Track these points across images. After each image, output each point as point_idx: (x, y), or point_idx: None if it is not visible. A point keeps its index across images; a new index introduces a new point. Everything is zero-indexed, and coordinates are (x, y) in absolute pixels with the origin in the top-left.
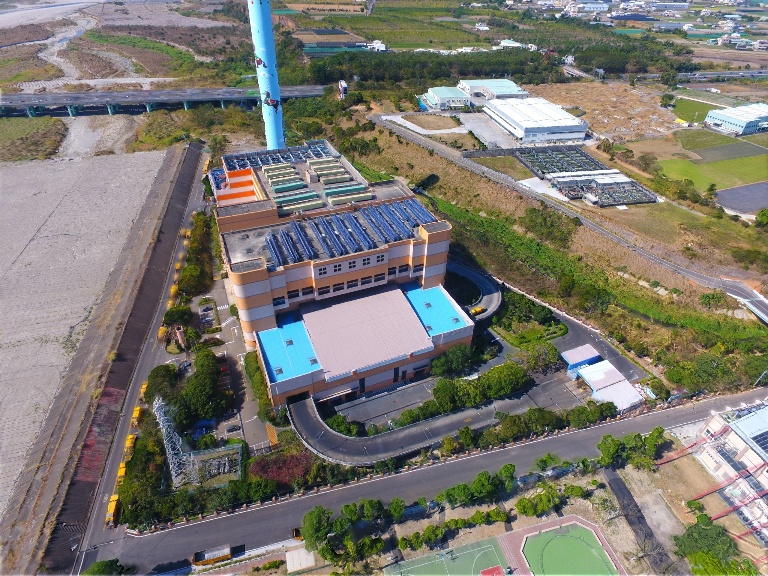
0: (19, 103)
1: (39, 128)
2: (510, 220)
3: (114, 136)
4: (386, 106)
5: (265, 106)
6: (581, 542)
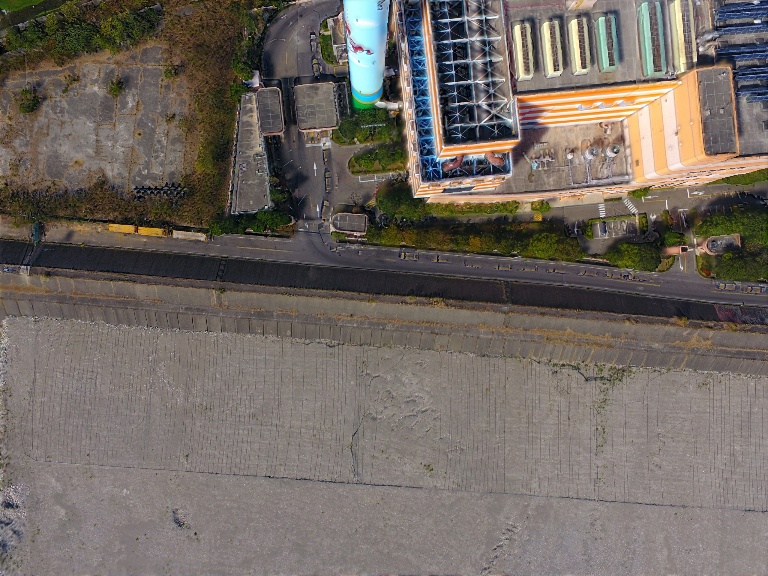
0: None
1: None
2: None
3: None
4: None
5: (384, 5)
6: None
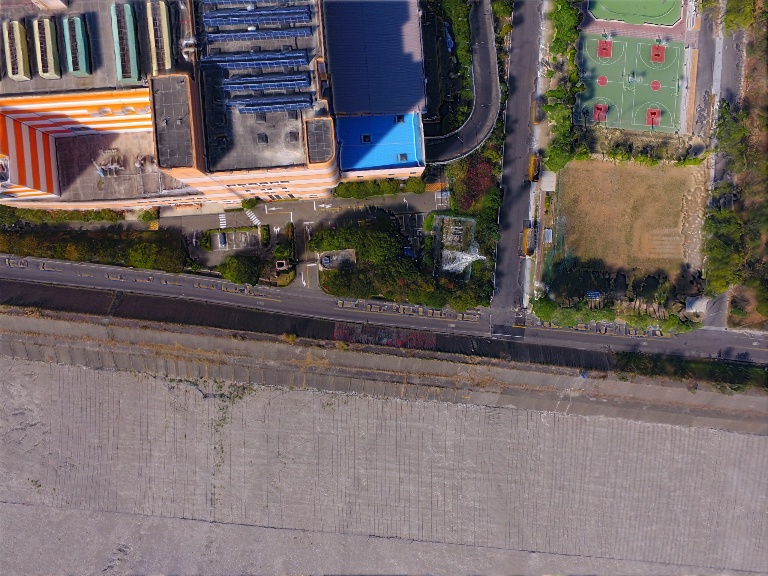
0: None
1: None
2: None
3: None
4: None
5: None
6: None
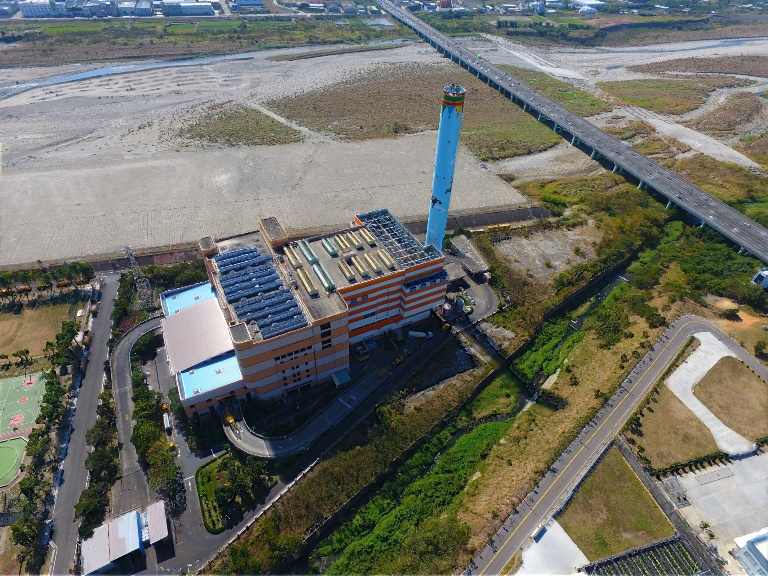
0: (556, 119)
1: (533, 141)
2: (456, 508)
3: (546, 172)
4: (766, 336)
5: None
6: (4, 473)
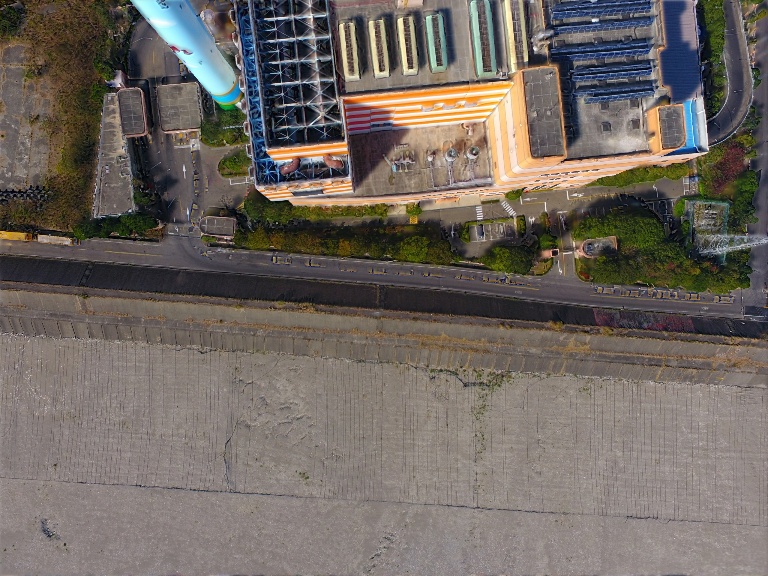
0: None
1: None
2: None
3: None
4: None
5: (168, 3)
6: None
